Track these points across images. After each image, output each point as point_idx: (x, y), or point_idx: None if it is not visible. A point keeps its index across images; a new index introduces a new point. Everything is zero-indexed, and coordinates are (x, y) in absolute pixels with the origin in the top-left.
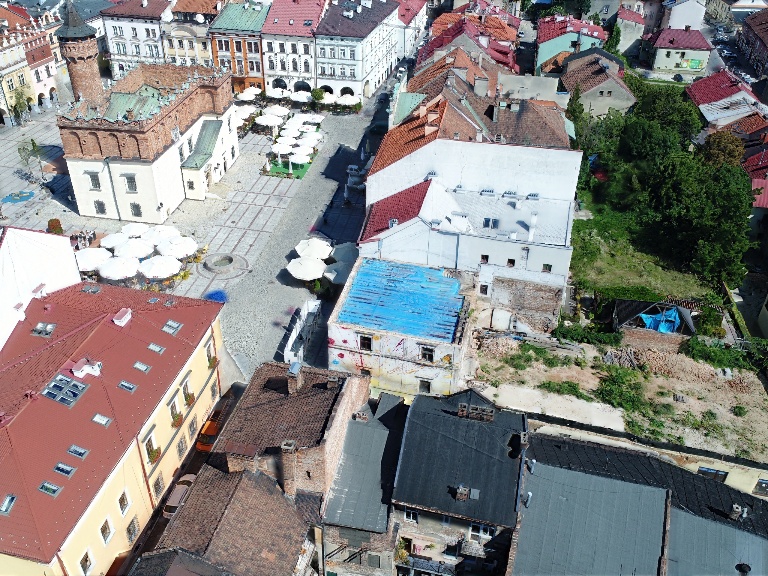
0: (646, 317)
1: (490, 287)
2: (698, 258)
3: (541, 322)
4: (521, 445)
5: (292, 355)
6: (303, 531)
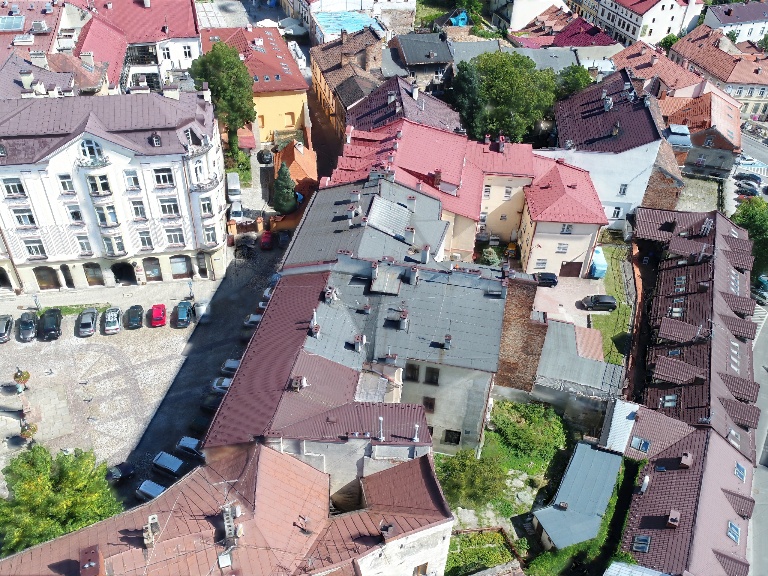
0: (453, 19)
1: (380, 17)
2: (459, 2)
3: (406, 33)
4: (445, 35)
5: (303, 61)
6: (379, 81)
